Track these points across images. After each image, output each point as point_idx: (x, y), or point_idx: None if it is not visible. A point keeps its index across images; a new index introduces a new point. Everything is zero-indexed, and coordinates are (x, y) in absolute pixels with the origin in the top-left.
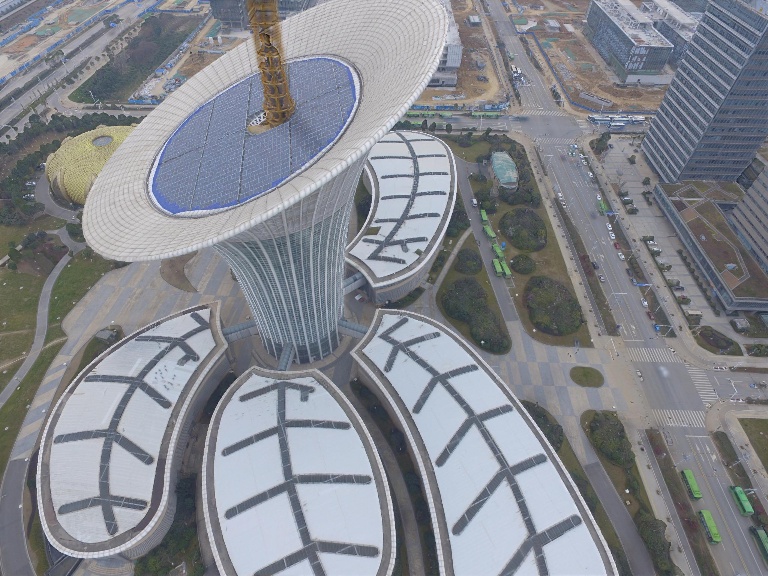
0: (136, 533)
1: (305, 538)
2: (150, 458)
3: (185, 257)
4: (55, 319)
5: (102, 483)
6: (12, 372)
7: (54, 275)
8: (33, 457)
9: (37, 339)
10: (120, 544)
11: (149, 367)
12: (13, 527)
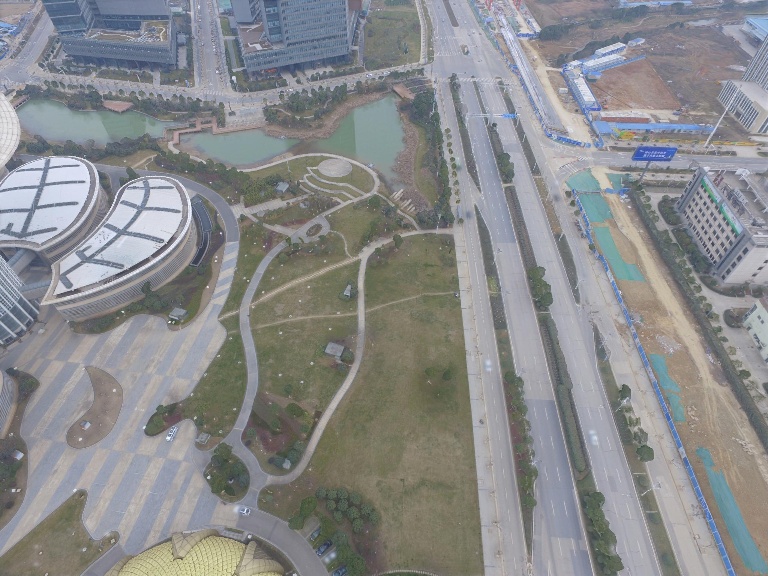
0: (134, 181)
1: (46, 171)
2: (122, 203)
3: (87, 419)
4: (234, 338)
5: (148, 193)
6: (258, 293)
7: (250, 395)
8: (222, 240)
9: (246, 319)
10: (142, 179)
11: (112, 241)
12: (226, 215)
